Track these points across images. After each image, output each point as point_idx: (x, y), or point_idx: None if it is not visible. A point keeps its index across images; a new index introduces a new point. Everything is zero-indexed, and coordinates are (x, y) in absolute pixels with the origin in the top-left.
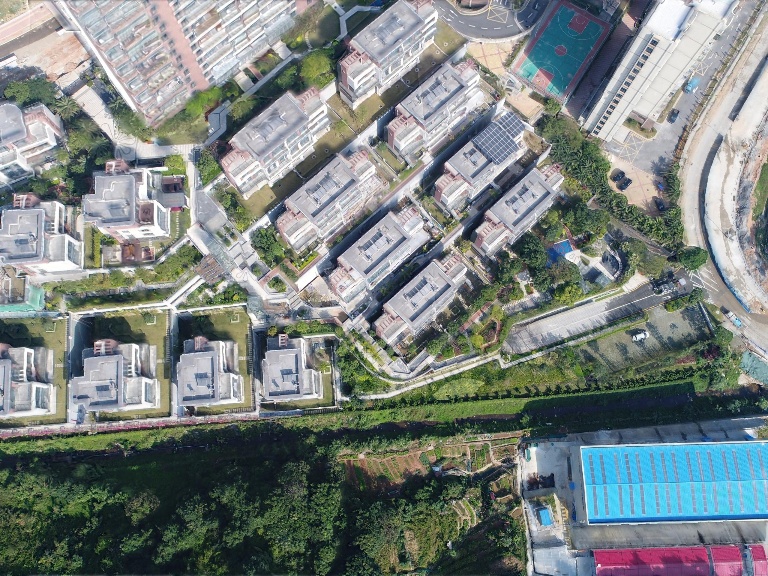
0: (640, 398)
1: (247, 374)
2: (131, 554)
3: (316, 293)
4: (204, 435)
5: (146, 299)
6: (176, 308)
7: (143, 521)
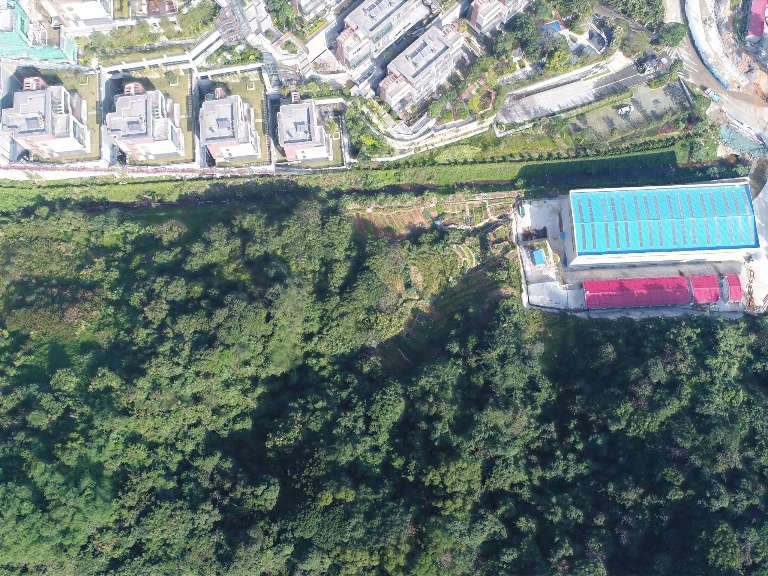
0: (626, 168)
1: (263, 134)
2: (163, 267)
3: (325, 64)
4: (224, 191)
5: (170, 51)
6: (197, 69)
7: (172, 246)
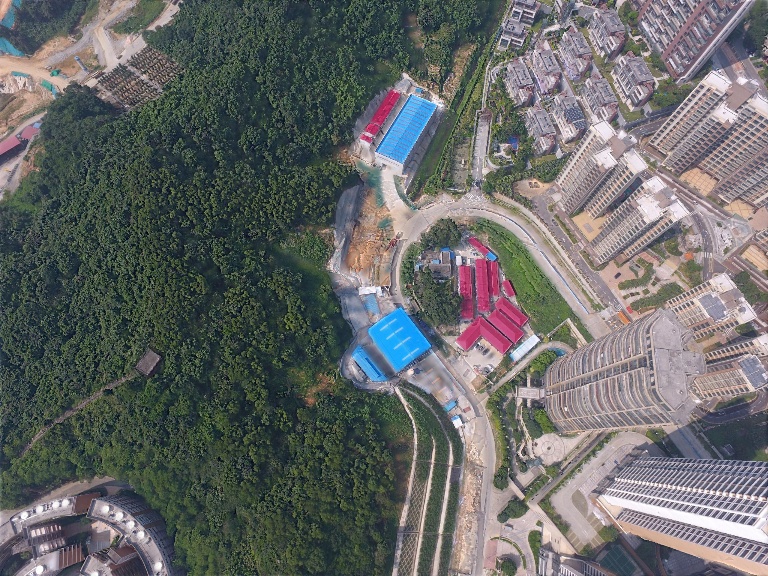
0: None
1: None
2: None
3: None
4: None
5: None
6: (554, 7)
7: None
